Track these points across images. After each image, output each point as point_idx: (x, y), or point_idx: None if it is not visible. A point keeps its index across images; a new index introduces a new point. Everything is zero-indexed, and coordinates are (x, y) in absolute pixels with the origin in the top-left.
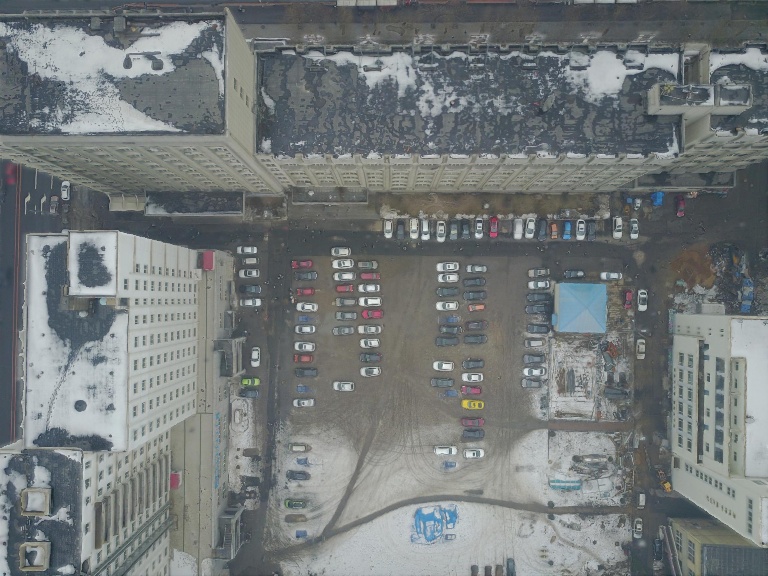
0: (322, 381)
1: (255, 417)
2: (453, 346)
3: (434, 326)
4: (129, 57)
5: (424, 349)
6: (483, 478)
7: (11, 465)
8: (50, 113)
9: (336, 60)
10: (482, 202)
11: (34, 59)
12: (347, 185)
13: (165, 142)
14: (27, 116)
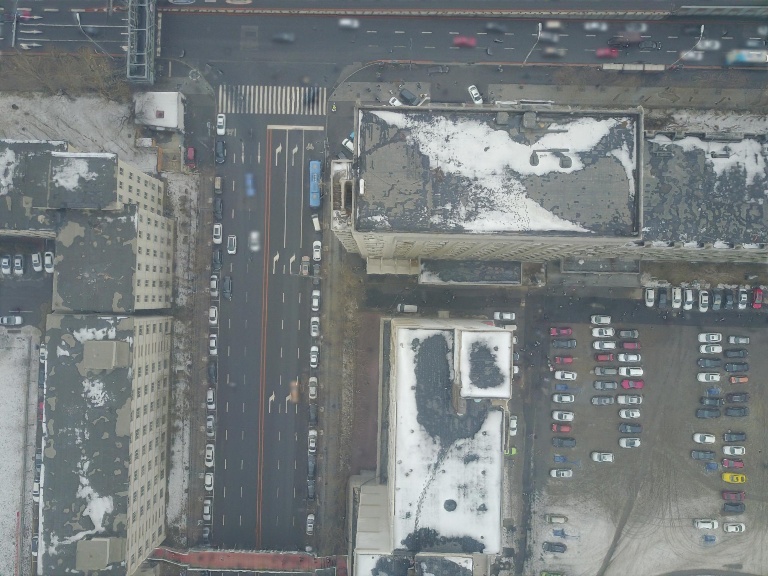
0: (579, 451)
1: (510, 487)
2: (714, 418)
3: (694, 397)
4: (536, 154)
5: (684, 420)
6: (742, 552)
7: (378, 566)
8: (453, 210)
9: (683, 145)
10: (745, 272)
11: (436, 153)
12: (627, 257)
13: (566, 241)
14: (428, 212)
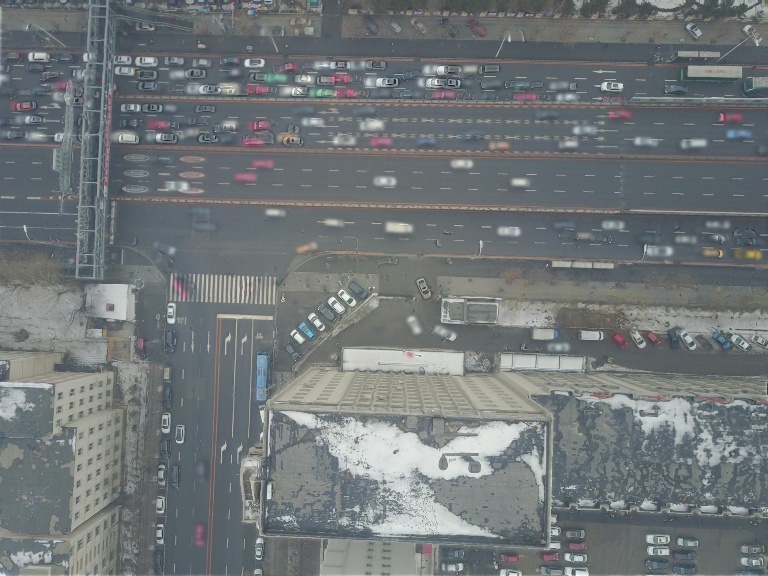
0: None
1: None
2: None
3: None
4: (445, 457)
5: None
6: None
7: None
8: (361, 512)
9: (611, 403)
10: None
11: (345, 454)
12: None
13: None
14: (336, 514)
